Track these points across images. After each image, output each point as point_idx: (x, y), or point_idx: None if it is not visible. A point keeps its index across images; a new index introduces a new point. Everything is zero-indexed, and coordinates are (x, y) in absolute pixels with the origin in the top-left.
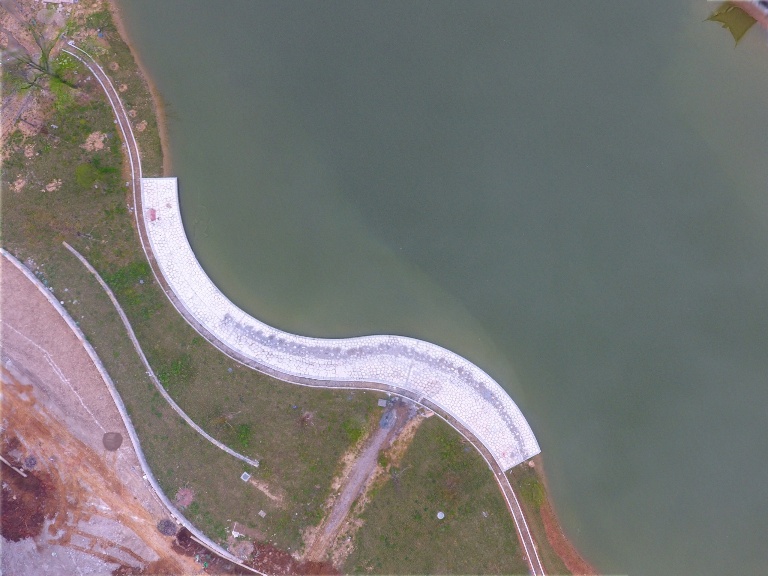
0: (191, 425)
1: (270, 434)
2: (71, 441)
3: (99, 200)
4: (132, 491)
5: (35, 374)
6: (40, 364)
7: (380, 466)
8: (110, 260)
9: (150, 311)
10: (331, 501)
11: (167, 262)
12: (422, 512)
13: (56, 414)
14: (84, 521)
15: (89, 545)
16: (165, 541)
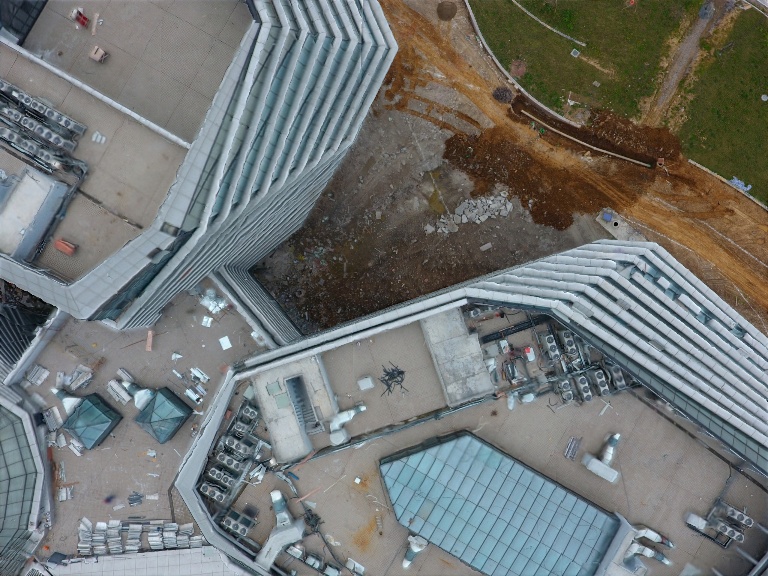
0: (518, 5)
1: (594, 19)
2: (405, 11)
3: None
4: (467, 60)
5: None
6: None
7: (704, 50)
8: None
9: None
10: (661, 77)
11: None
12: (748, 92)
13: None
14: (421, 86)
15: (426, 110)
16: (500, 109)
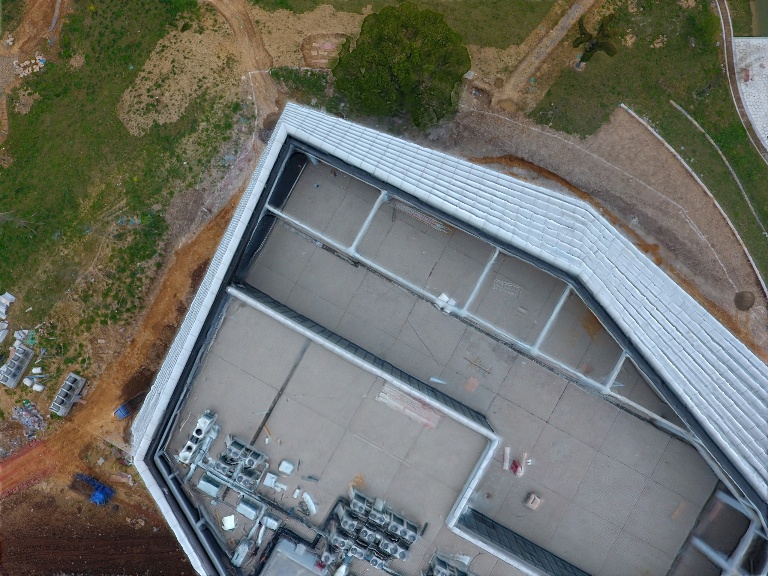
0: None
1: None
2: (700, 301)
3: (697, 59)
4: (767, 351)
5: (671, 231)
6: (676, 220)
7: None
8: (713, 120)
9: (754, 172)
10: None
11: (762, 124)
12: None
13: (684, 274)
14: None
15: None
16: None
